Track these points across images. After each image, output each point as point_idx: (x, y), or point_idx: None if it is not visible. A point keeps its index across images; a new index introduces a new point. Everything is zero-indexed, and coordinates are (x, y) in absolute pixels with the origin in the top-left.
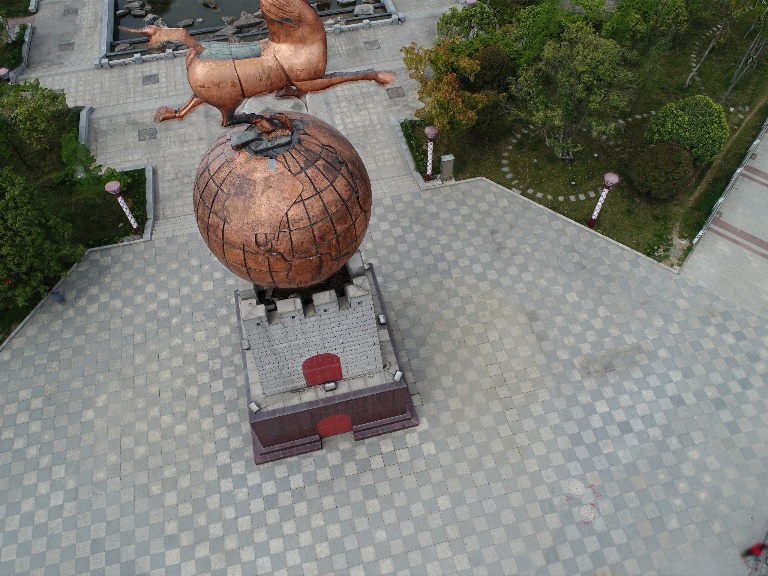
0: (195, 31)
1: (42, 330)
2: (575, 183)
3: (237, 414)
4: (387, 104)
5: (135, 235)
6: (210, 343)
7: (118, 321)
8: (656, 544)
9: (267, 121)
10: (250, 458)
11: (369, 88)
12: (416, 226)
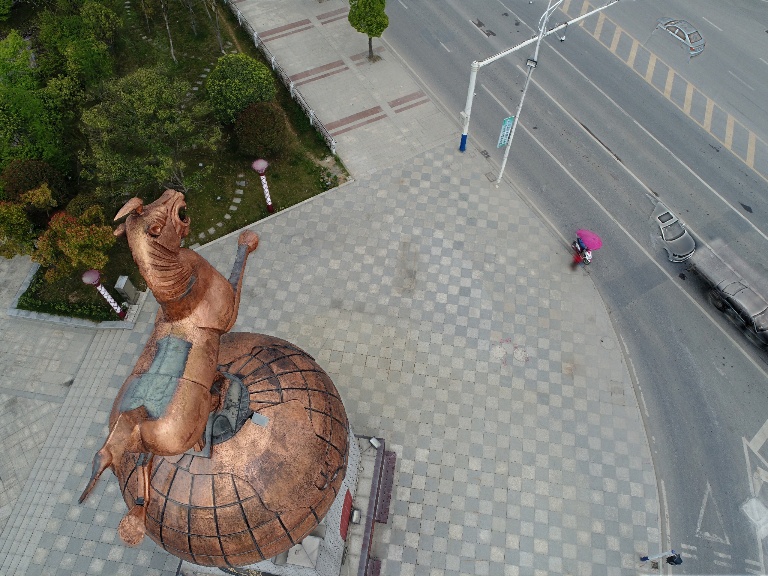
0: None
1: None
2: (220, 197)
3: None
4: None
5: None
6: None
7: None
8: (556, 322)
9: None
10: None
11: None
12: None
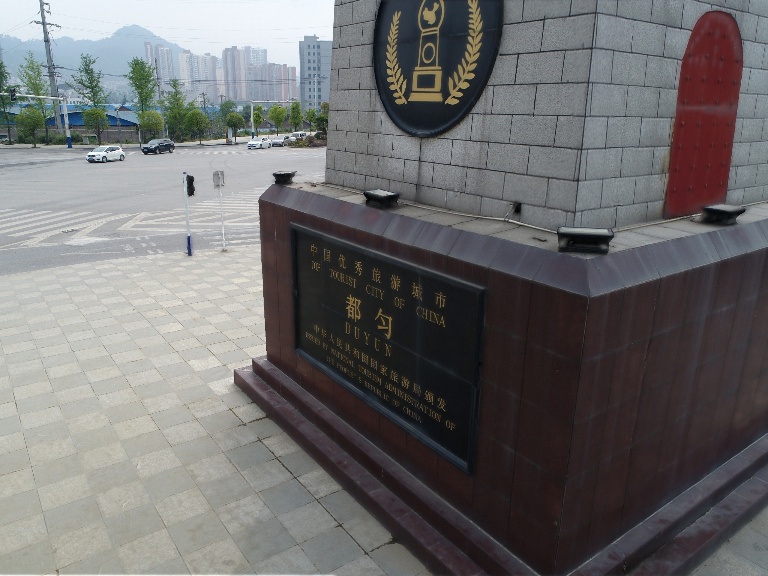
0: None
1: None
2: None
3: None
4: None
5: None
6: None
7: None
8: None
9: None
10: None
11: None
12: None
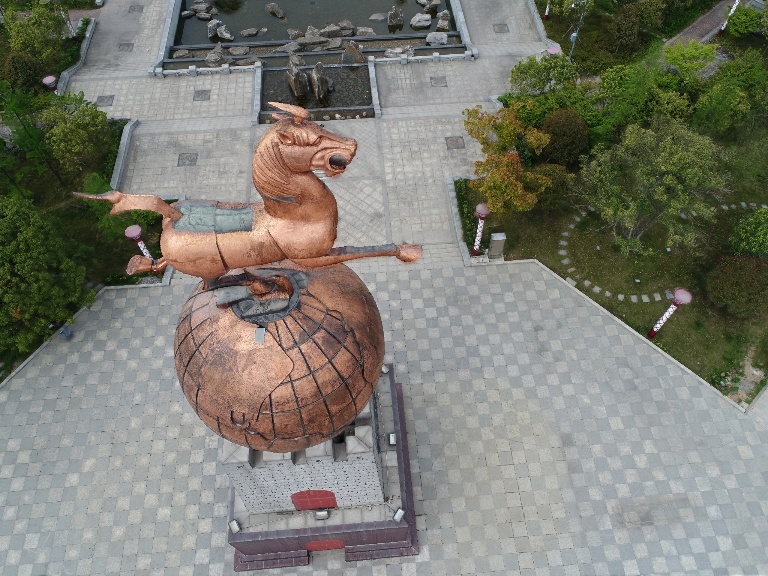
0: (257, 43)
1: (43, 373)
2: (640, 281)
3: (225, 506)
4: (444, 155)
5: (154, 277)
6: None
7: (121, 375)
8: None
9: (261, 283)
10: (230, 561)
11: (427, 134)
12: (453, 309)
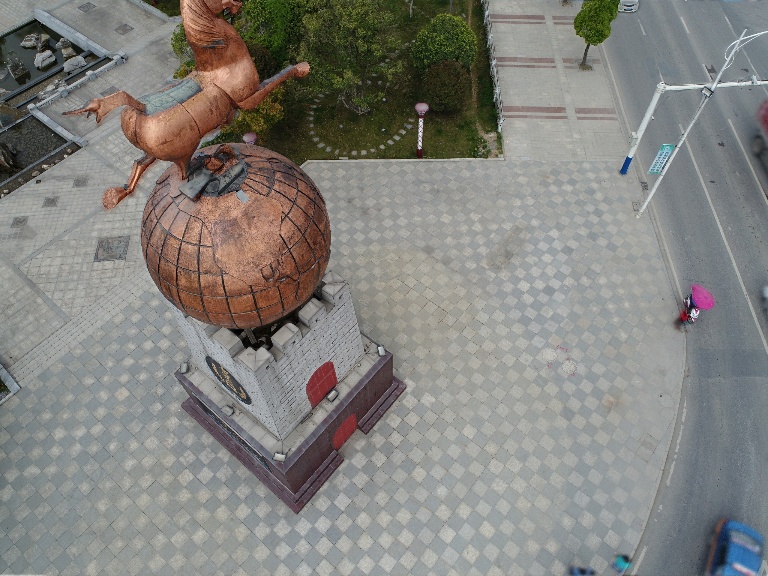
0: None
1: None
2: (385, 129)
3: (244, 486)
4: None
5: None
6: (167, 443)
7: (48, 486)
8: (623, 357)
9: (214, 158)
10: (286, 513)
11: None
12: None
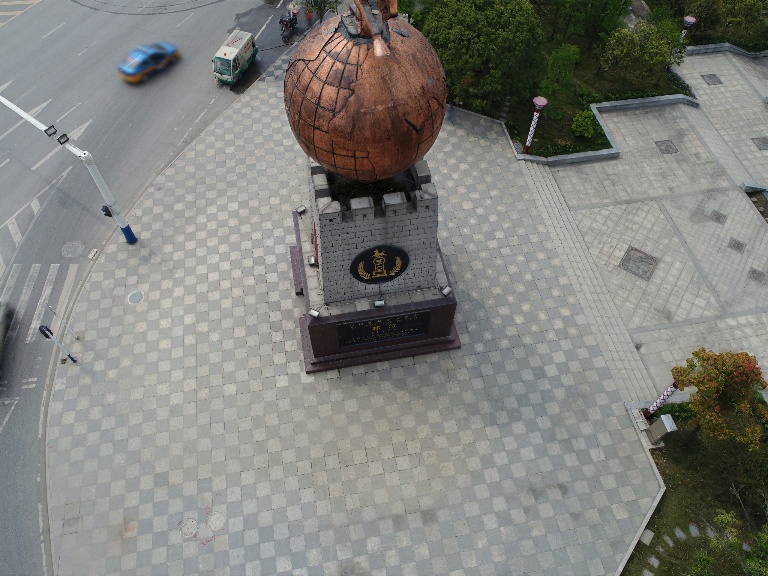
0: None
1: None
2: None
3: None
4: None
5: (523, 149)
6: None
7: (430, 151)
8: None
9: None
10: None
11: None
12: (562, 392)
